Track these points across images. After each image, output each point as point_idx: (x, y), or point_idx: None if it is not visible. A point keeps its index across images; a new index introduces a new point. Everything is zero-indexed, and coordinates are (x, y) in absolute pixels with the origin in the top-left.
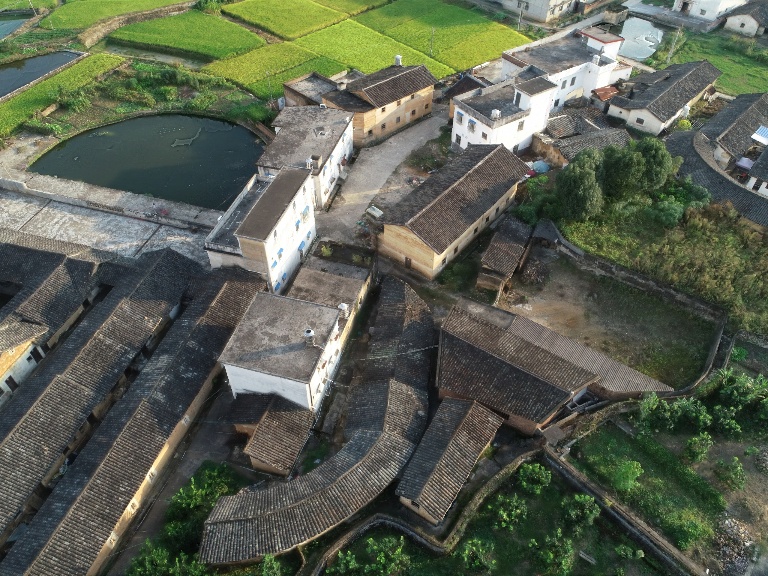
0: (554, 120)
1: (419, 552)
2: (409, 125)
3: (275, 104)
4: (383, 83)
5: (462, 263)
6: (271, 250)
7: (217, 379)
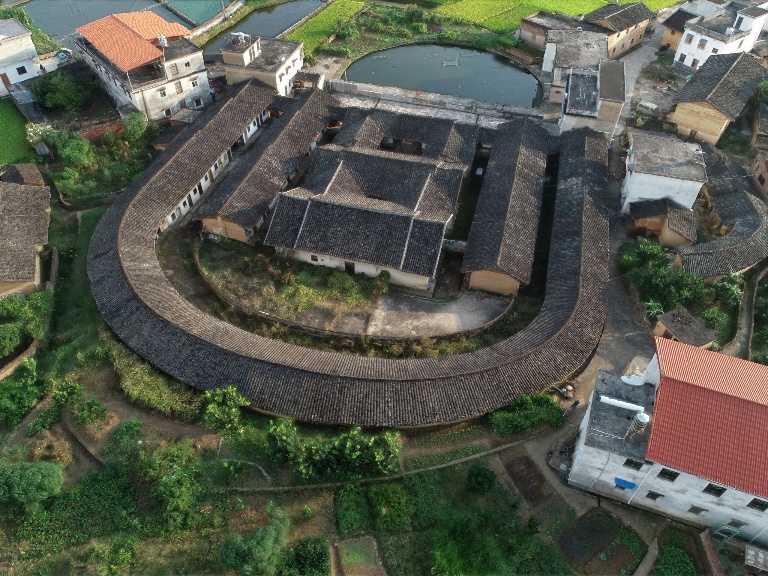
0: (757, 43)
1: None
2: (628, 51)
3: (513, 36)
4: (617, 14)
5: None
6: None
7: None
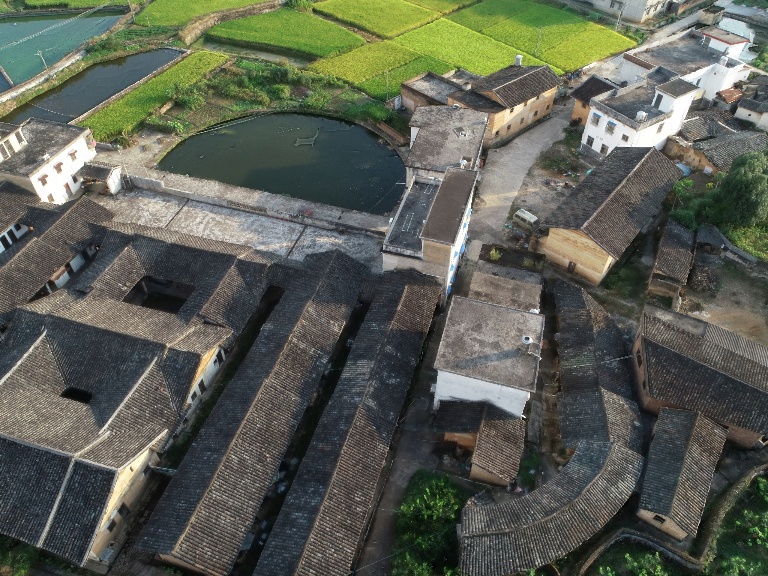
0: (687, 122)
1: (669, 569)
2: (531, 126)
3: None
4: (511, 83)
5: (624, 268)
6: (452, 253)
7: (410, 385)
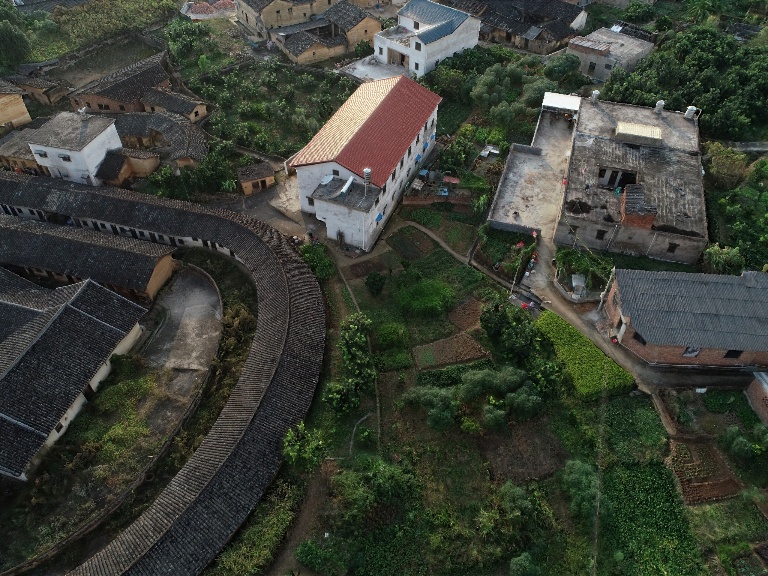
0: None
1: None
2: None
3: None
4: None
5: None
6: None
7: None
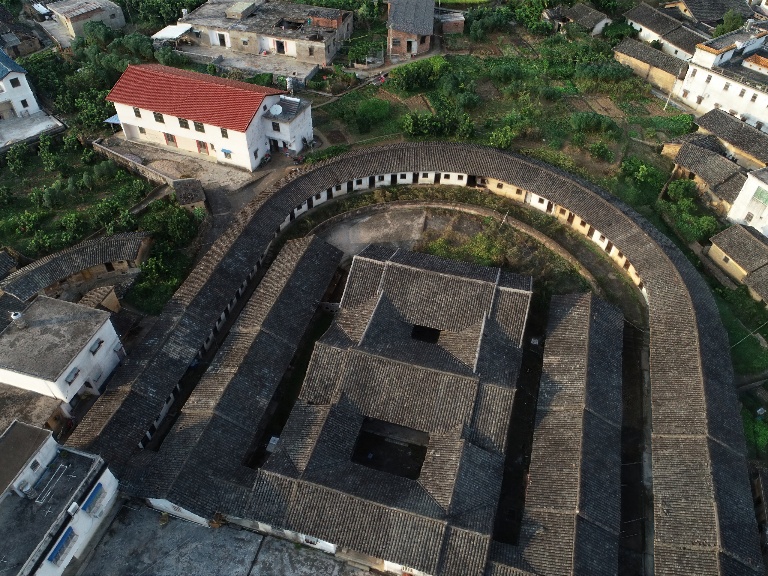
0: None
1: (24, 255)
2: None
3: None
4: None
5: None
6: None
7: None
